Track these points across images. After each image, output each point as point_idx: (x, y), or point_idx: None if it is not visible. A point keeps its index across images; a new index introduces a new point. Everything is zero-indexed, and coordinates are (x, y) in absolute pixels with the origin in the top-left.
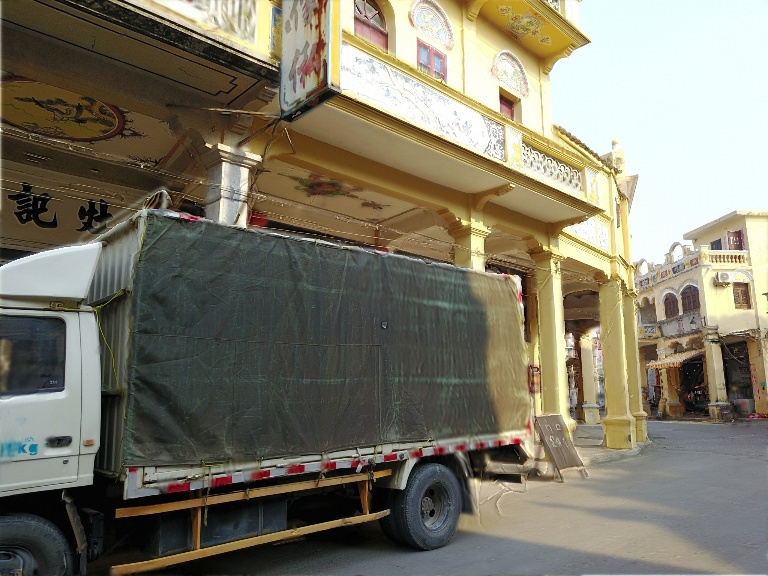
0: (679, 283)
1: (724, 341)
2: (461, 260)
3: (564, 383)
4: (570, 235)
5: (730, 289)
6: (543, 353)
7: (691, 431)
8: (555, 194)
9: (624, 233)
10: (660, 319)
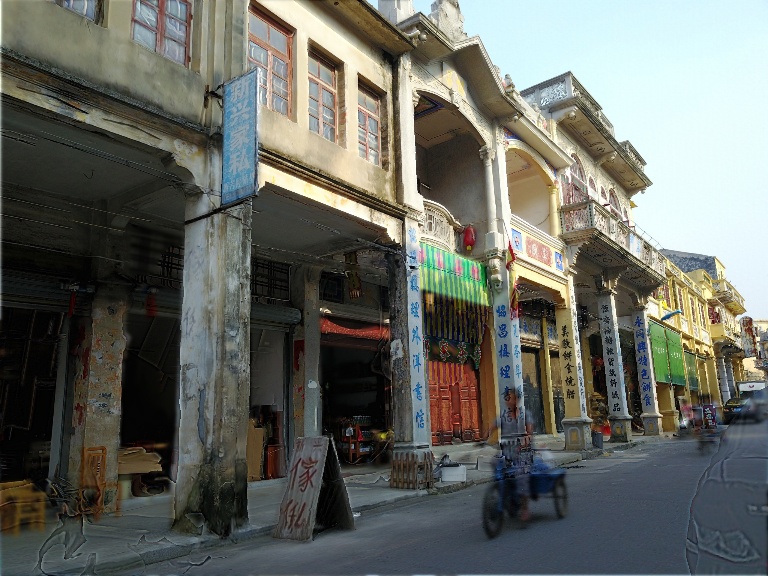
0: None
1: None
2: (736, 370)
3: None
4: None
5: None
6: None
7: None
8: None
9: None
10: None
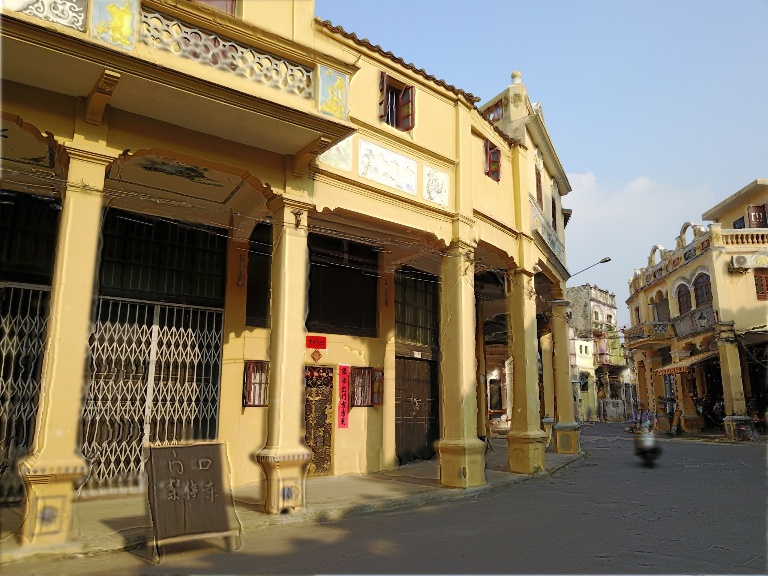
0: (691, 271)
1: (750, 341)
2: None
3: (295, 392)
4: (343, 176)
5: (750, 276)
6: (272, 347)
7: (657, 455)
8: (230, 95)
9: (515, 190)
10: (673, 316)
